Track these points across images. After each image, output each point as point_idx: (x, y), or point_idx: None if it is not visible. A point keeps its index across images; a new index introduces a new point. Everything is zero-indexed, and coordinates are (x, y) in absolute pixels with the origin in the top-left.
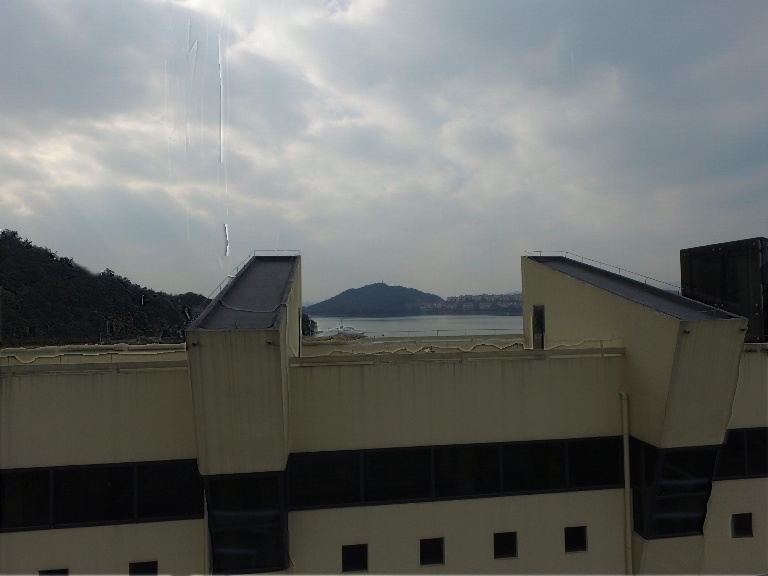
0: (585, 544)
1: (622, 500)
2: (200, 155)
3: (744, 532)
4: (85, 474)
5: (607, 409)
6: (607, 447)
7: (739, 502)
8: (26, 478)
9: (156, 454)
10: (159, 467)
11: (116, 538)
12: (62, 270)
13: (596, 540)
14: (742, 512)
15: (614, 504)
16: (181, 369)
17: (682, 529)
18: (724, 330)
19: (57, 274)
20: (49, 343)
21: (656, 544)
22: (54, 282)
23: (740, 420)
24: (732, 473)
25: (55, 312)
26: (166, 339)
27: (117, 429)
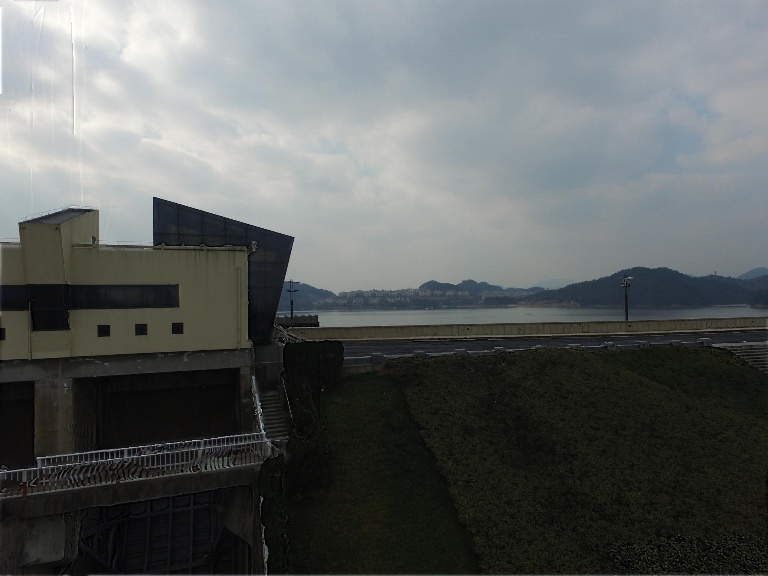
0: (5, 337)
1: (28, 316)
2: (49, 133)
3: (105, 334)
4: None
5: (22, 272)
6: (21, 291)
7: (102, 320)
8: None
9: None
10: None
11: None
12: None
13: (11, 335)
14: (104, 324)
15: (23, 318)
16: None
17: (56, 328)
18: (47, 228)
19: None
20: None
21: (38, 334)
22: None
23: (106, 281)
24: (100, 306)
25: None
26: None
27: None
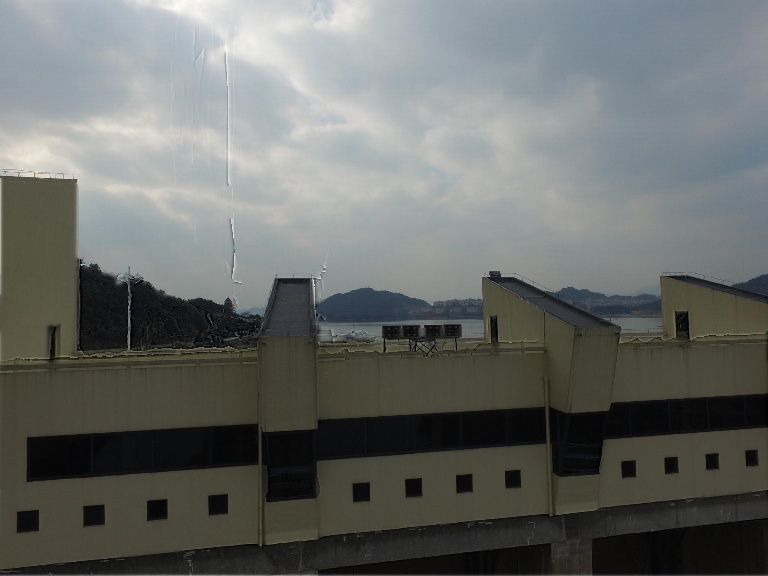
0: None
1: None
2: (205, 161)
3: None
4: (723, 401)
5: None
6: None
7: None
8: (693, 404)
9: (754, 391)
10: (756, 398)
11: (739, 437)
12: (95, 276)
13: None
14: None
15: None
16: (763, 343)
17: None
18: None
19: (92, 280)
20: (93, 348)
21: None
22: (91, 288)
23: None
24: None
25: (96, 318)
26: (198, 344)
27: (735, 377)
